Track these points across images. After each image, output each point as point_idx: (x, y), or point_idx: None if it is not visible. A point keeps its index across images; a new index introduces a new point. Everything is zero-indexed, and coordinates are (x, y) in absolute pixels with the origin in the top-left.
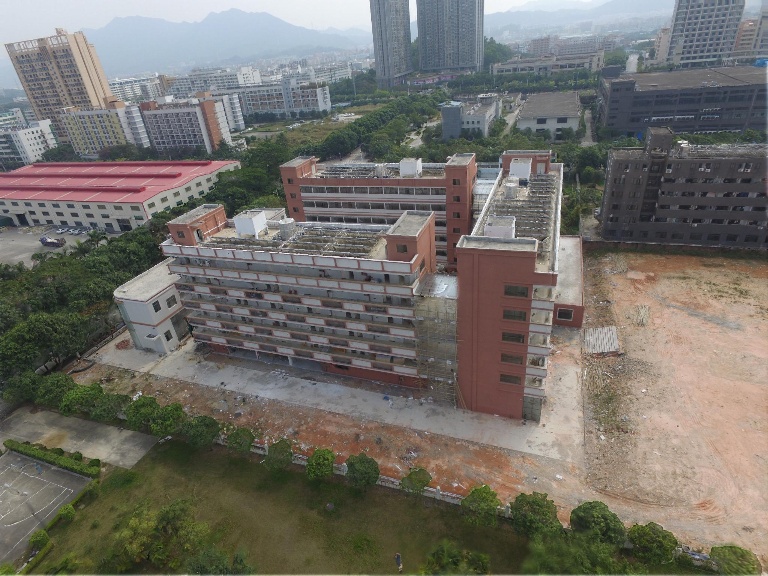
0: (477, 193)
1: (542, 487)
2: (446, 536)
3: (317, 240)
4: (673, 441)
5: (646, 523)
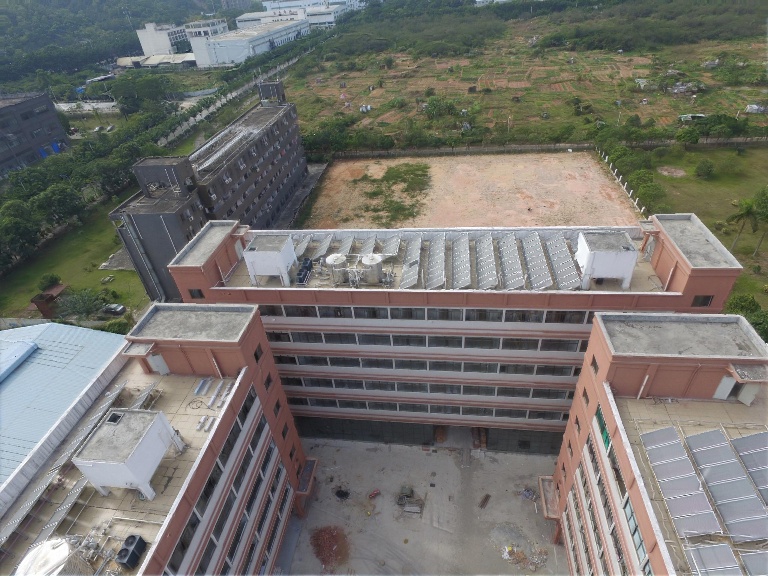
0: None
1: None
2: None
3: None
4: None
5: None
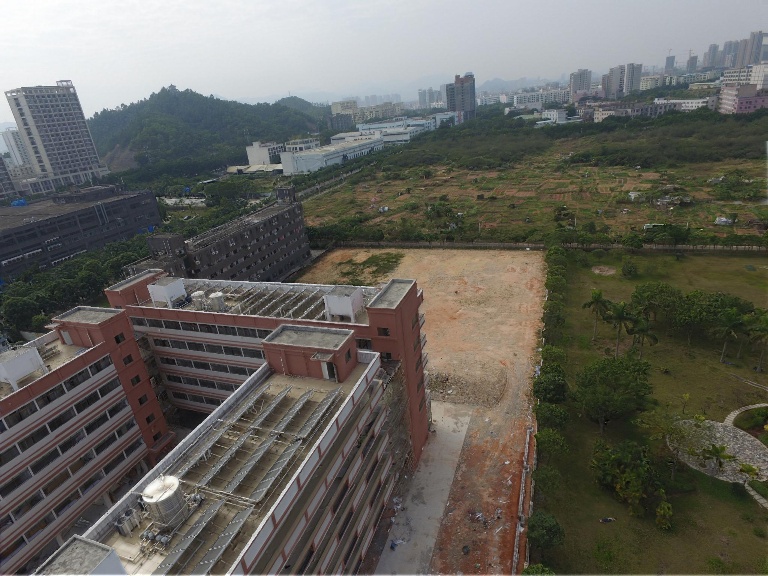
0: None
1: (499, 430)
2: (568, 486)
3: (230, 462)
4: (455, 363)
5: (520, 387)
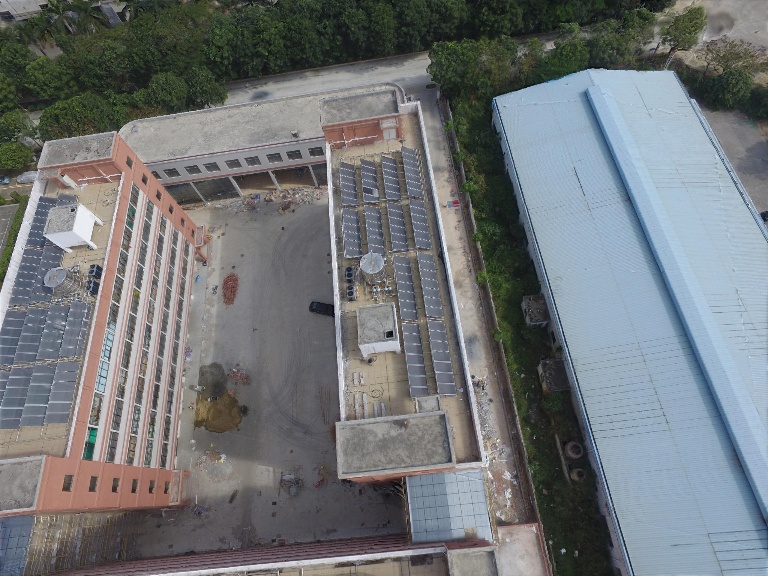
0: (404, 490)
1: None
2: None
3: None
4: None
5: None
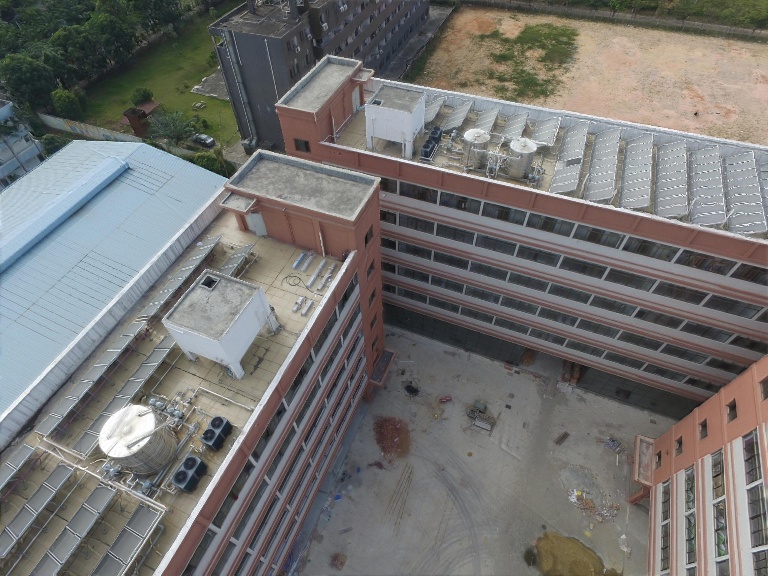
0: None
1: None
2: None
3: None
4: None
5: None
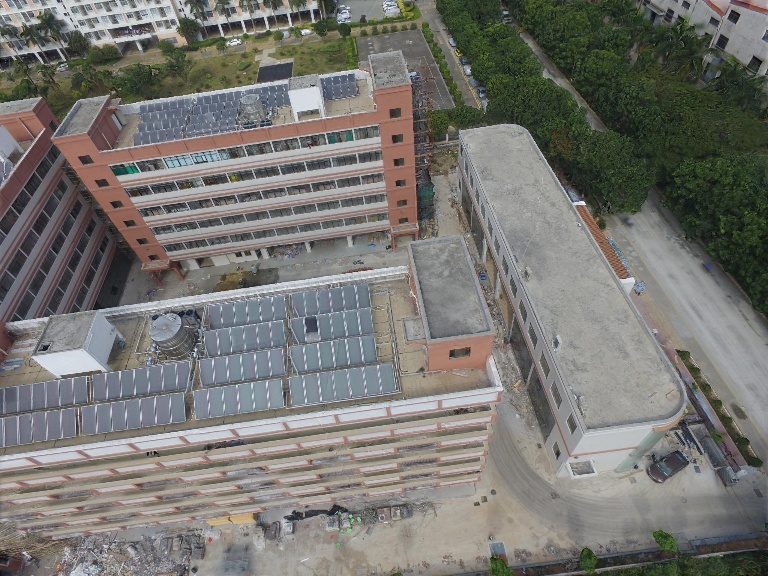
0: None
1: None
2: None
3: None
4: None
5: None
